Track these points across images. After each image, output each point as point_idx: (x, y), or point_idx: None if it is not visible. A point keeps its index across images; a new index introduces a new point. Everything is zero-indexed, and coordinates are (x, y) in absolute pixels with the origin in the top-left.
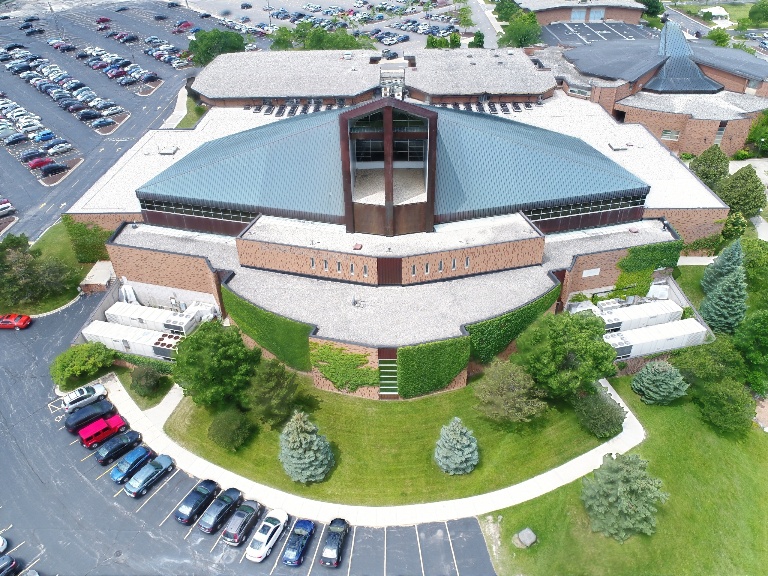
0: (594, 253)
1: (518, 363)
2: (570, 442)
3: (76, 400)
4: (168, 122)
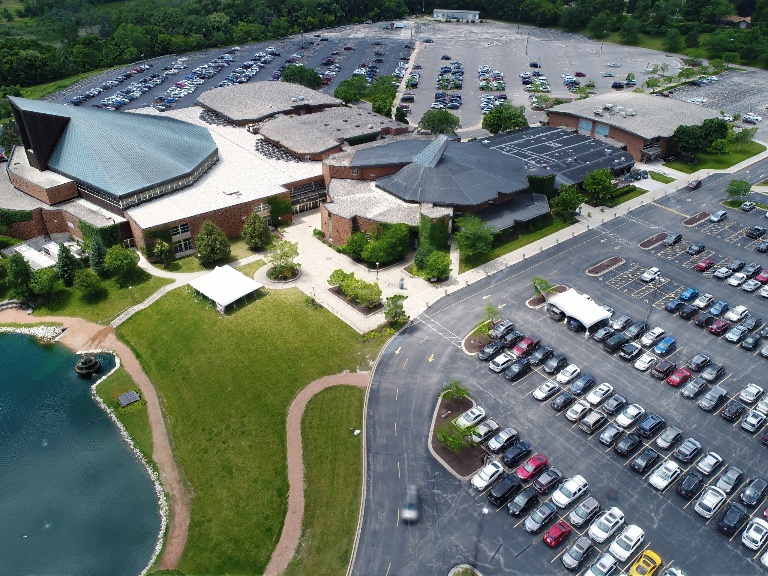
0: (67, 212)
1: None
2: None
3: None
4: None
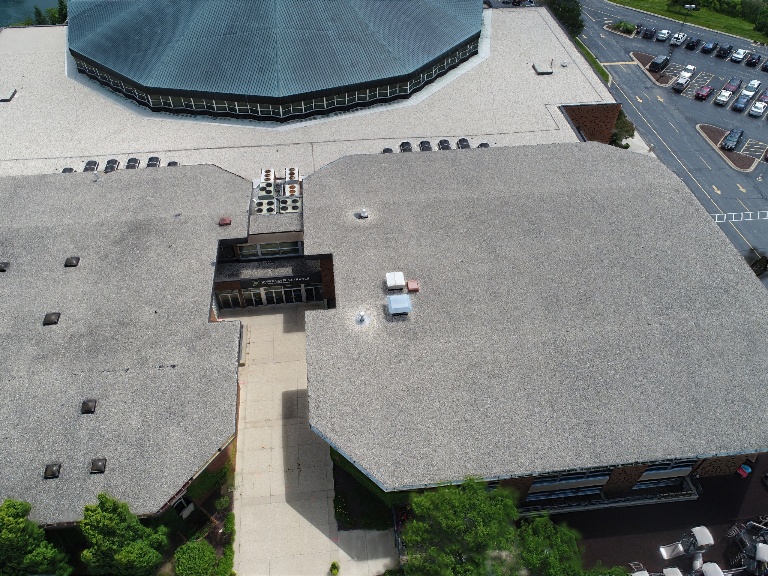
0: None
1: None
2: None
3: None
4: None
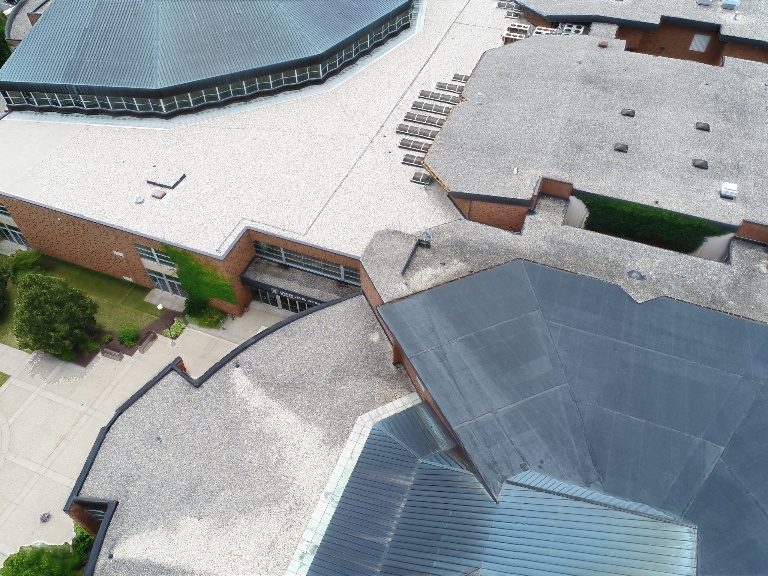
0: None
1: None
2: None
3: None
4: None
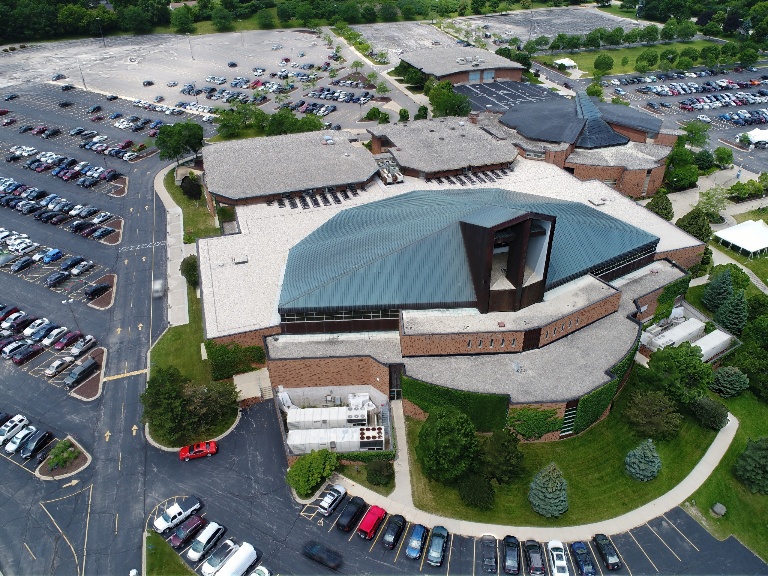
0: (646, 295)
1: (651, 390)
2: (699, 437)
3: (332, 503)
4: (171, 222)
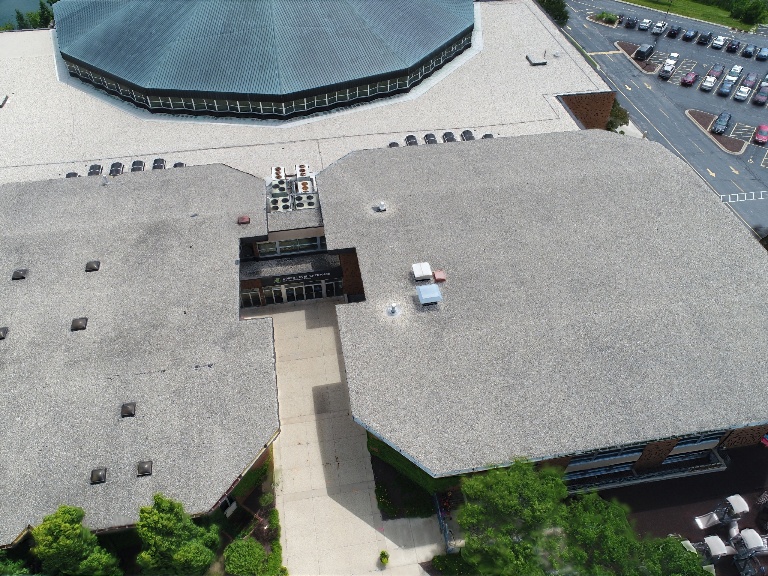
0: None
1: None
2: None
3: None
4: None
